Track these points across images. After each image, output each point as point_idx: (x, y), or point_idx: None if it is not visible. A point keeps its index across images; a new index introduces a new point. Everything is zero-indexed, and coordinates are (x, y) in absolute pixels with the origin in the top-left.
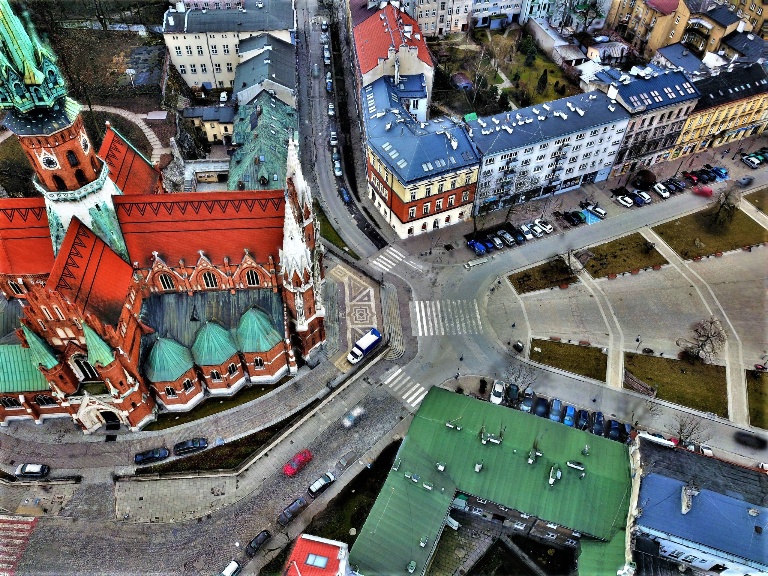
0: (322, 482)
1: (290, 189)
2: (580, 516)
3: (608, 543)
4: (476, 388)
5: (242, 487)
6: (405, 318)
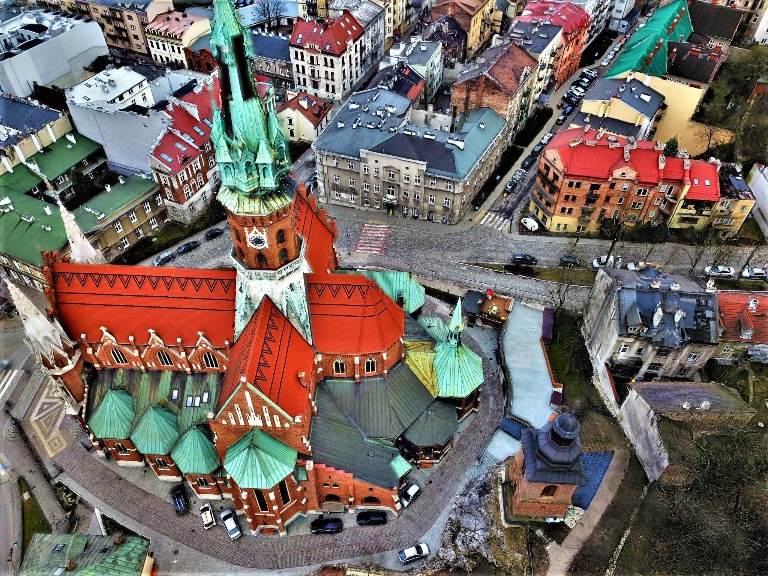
0: (162, 256)
1: (50, 258)
2: (8, 192)
3: (4, 185)
4: (4, 320)
5: (219, 263)
6: (19, 390)
